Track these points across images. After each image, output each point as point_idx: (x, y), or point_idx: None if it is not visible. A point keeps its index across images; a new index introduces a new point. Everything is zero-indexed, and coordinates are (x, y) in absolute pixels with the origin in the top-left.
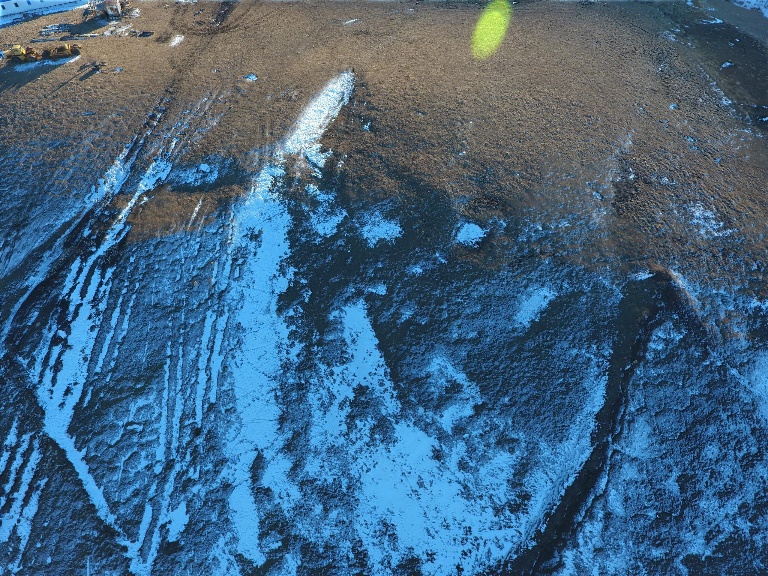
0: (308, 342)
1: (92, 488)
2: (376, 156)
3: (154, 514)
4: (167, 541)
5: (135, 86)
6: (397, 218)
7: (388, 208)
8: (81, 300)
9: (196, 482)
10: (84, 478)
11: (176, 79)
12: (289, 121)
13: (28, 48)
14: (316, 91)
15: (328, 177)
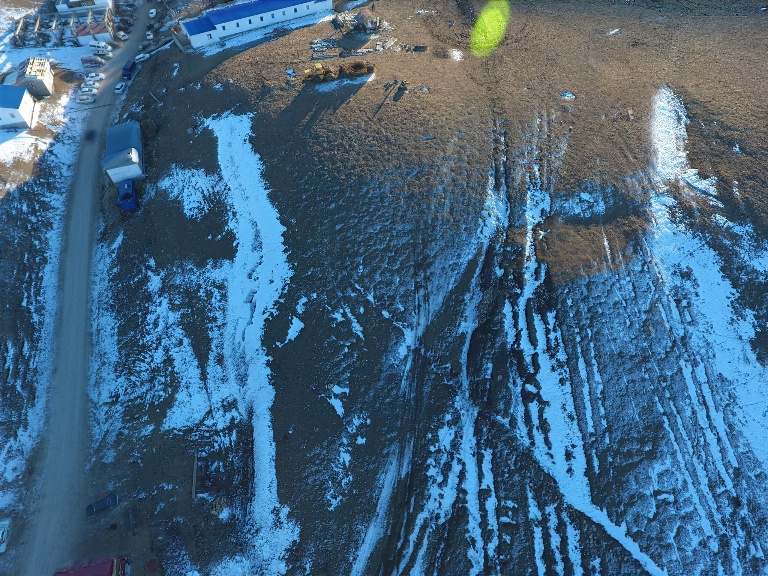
0: None
1: (655, 570)
2: None
3: None
4: None
5: (457, 107)
6: None
7: None
8: (534, 349)
9: (764, 561)
10: (639, 558)
11: (494, 98)
12: (645, 143)
13: None
14: (649, 109)
15: (732, 206)
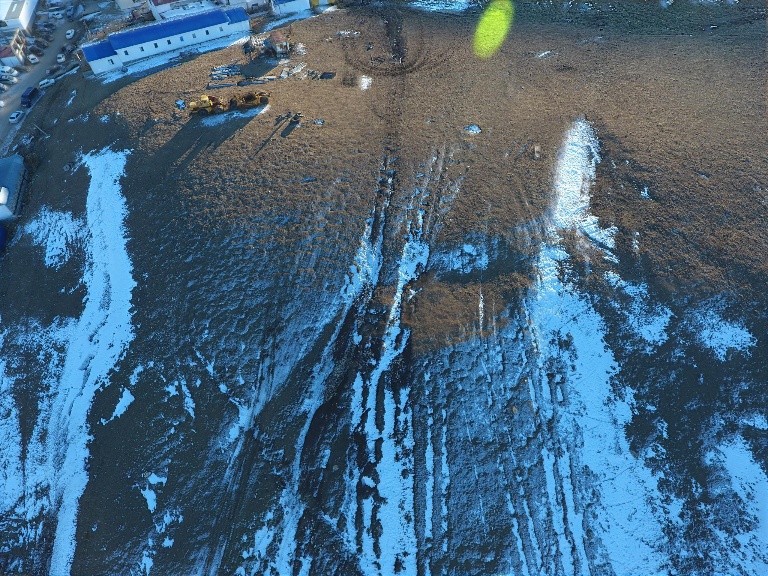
0: (689, 497)
1: None
2: (677, 234)
3: None
4: None
5: (348, 143)
6: (740, 320)
7: (723, 306)
8: (379, 433)
9: None
10: None
11: (391, 133)
12: (546, 186)
13: (209, 97)
14: (559, 146)
15: (628, 262)
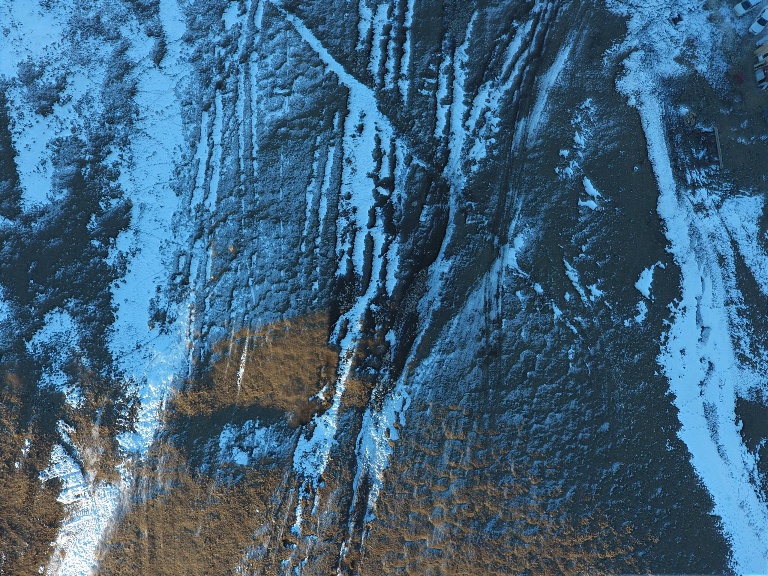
0: (96, 165)
1: (312, 40)
2: None
3: (253, 21)
4: (239, 1)
5: None
6: None
7: None
8: (370, 232)
9: (217, 44)
10: (321, 49)
11: None
12: (111, 567)
13: None
14: None
15: (47, 419)
